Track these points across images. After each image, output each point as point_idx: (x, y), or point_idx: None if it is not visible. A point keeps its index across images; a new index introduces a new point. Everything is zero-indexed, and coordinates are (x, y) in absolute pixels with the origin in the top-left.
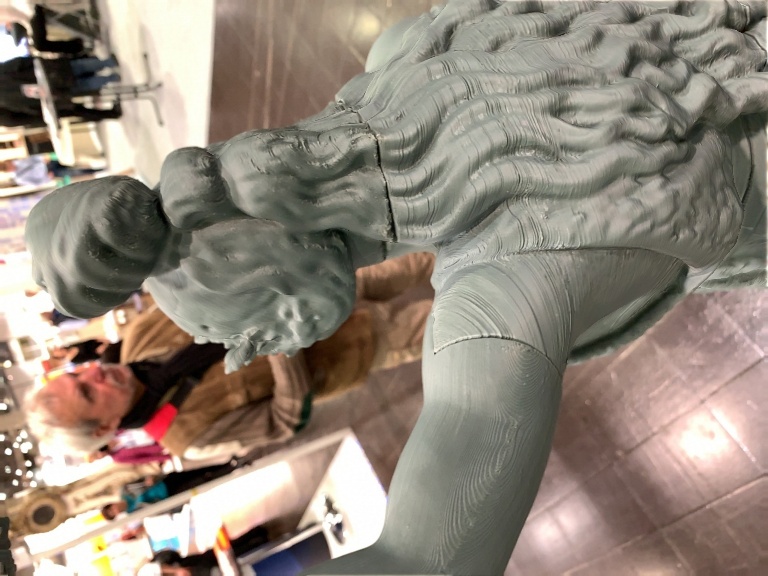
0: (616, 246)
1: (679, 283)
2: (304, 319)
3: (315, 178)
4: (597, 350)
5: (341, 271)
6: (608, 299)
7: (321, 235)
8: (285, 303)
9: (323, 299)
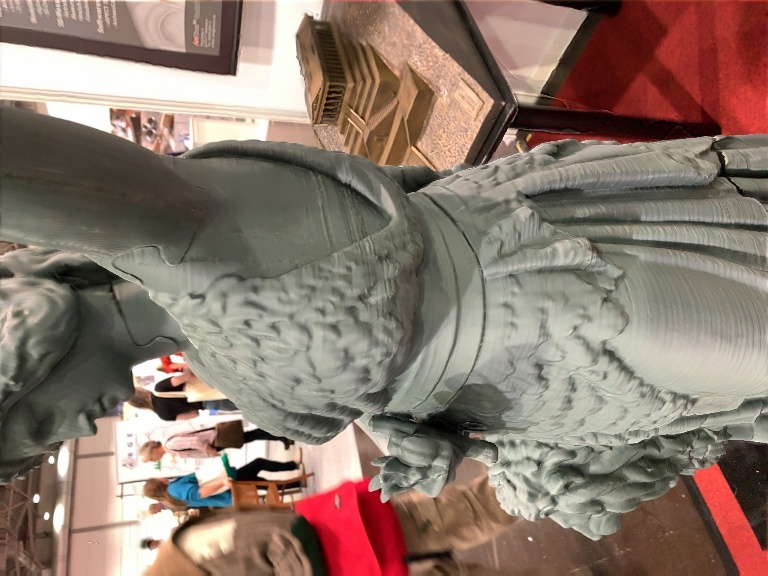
0: (213, 150)
1: (387, 218)
2: (14, 313)
3: (46, 251)
4: (321, 258)
5: (57, 287)
6: (232, 171)
7: (47, 277)
8: (3, 313)
9: (34, 298)
